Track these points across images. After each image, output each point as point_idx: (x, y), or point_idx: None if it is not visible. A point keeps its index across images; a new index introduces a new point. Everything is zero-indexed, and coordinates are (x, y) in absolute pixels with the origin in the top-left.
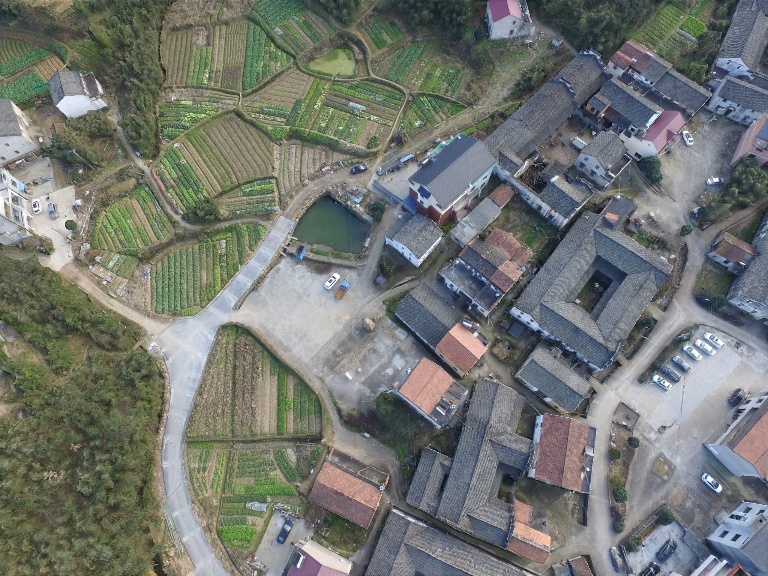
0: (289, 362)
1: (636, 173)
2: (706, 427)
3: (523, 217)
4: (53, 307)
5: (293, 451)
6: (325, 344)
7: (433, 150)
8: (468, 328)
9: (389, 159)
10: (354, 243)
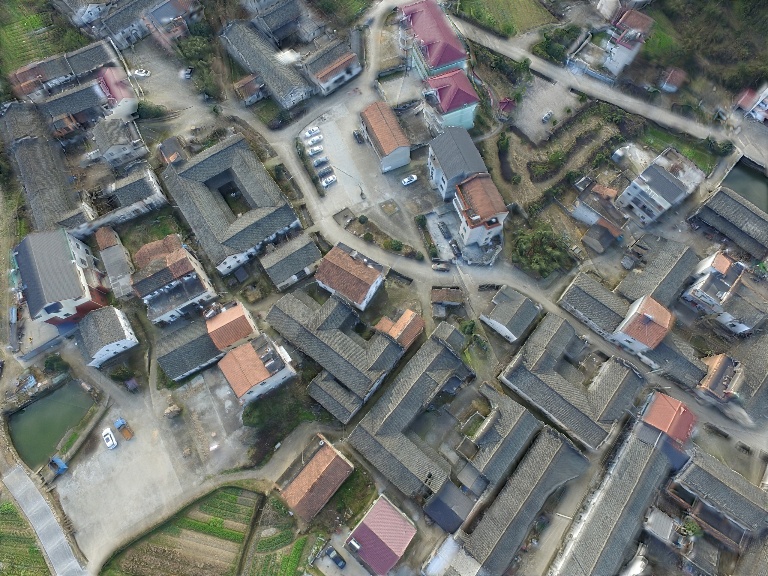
0: (174, 512)
1: (151, 123)
2: (372, 166)
3: (140, 228)
4: None
5: (265, 530)
6: (172, 465)
7: (15, 284)
8: (215, 314)
9: (6, 335)
10: (81, 402)
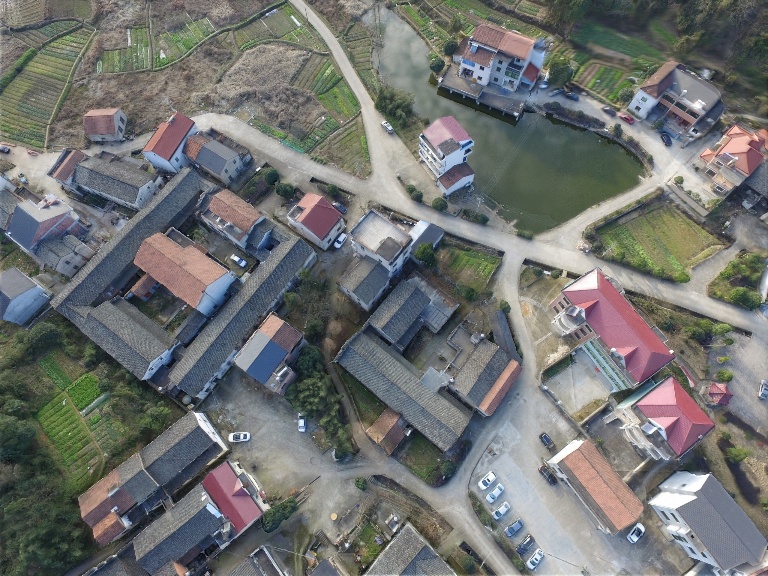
0: None
1: None
2: (579, 519)
3: None
4: None
5: None
6: None
7: None
8: None
9: None
10: None
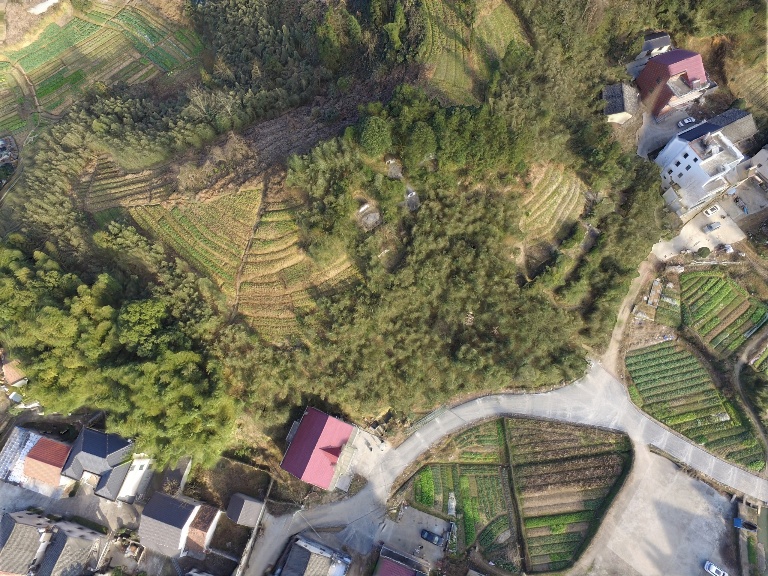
0: (604, 524)
1: None
2: None
3: None
4: (621, 271)
5: (509, 538)
6: (634, 569)
7: None
8: None
9: None
10: None
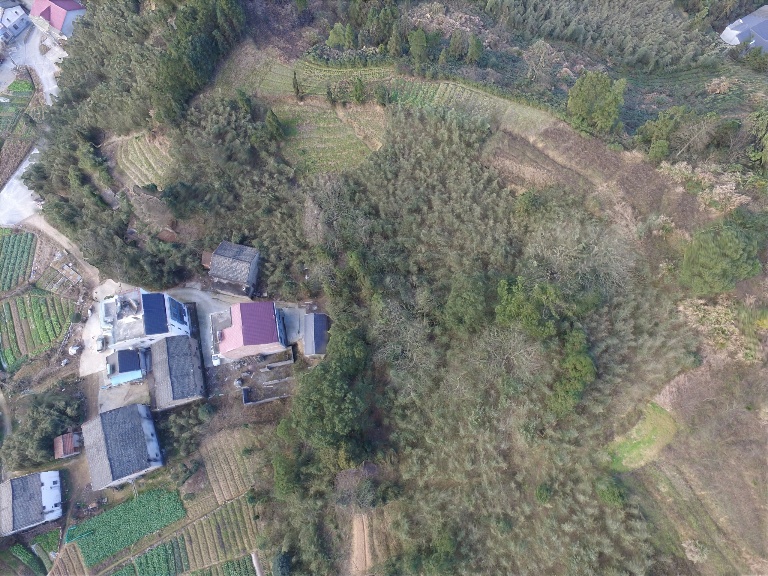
0: None
1: None
2: None
3: None
4: (73, 217)
5: None
6: None
7: None
8: None
9: None
10: None
